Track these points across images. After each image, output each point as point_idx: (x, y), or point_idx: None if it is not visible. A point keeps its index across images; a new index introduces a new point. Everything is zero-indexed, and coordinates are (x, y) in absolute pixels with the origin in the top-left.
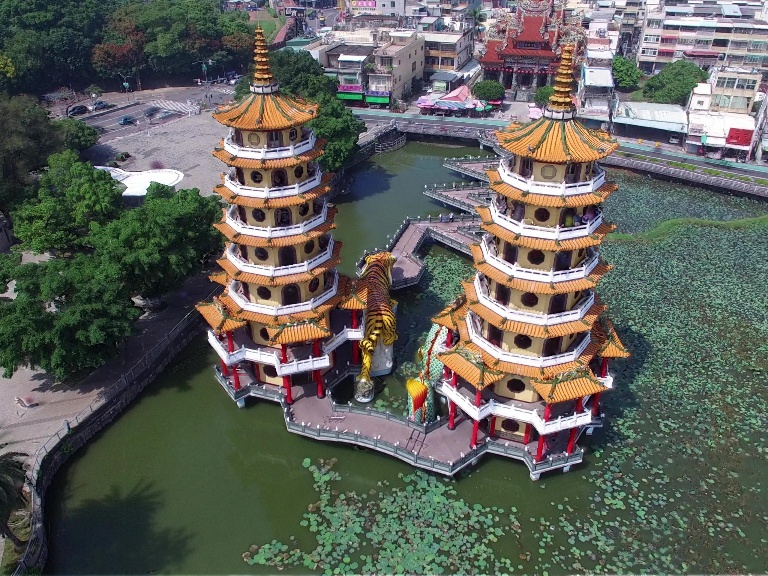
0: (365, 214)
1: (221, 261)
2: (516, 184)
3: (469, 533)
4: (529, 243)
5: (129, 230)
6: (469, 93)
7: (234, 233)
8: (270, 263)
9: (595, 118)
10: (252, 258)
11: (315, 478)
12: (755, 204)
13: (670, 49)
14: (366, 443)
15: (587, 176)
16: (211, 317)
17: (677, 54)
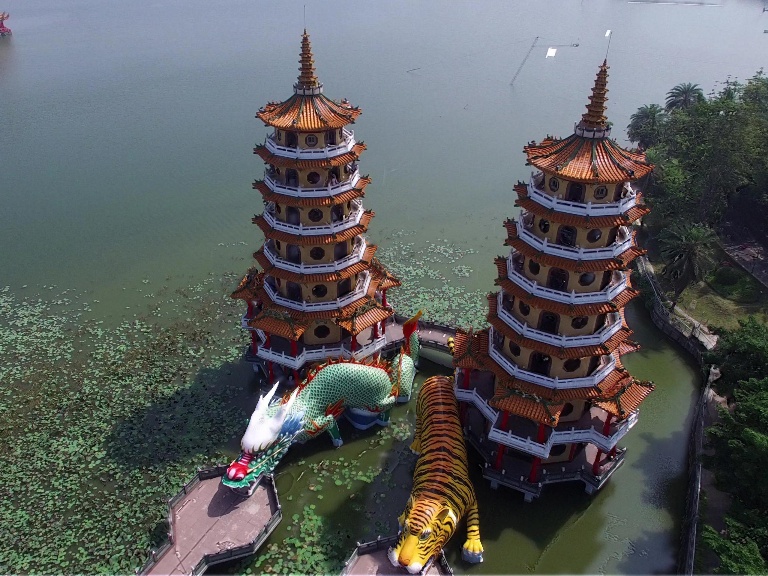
0: None
1: None
2: None
3: None
4: None
5: None
6: None
7: None
8: None
9: None
10: None
11: None
12: None
13: None
14: None
15: None
16: None
17: None
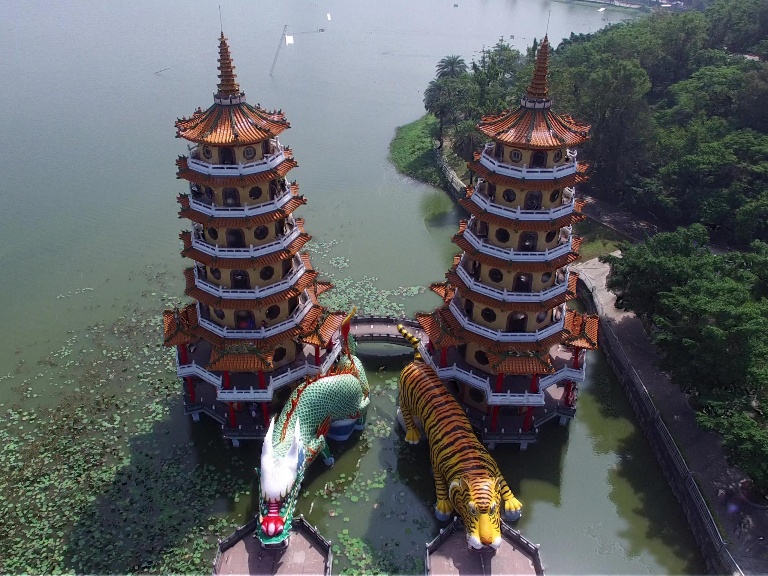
0: None
1: None
2: None
3: None
4: None
5: None
6: None
7: None
8: None
9: None
10: None
11: None
12: None
13: None
14: None
15: None
16: None
17: None
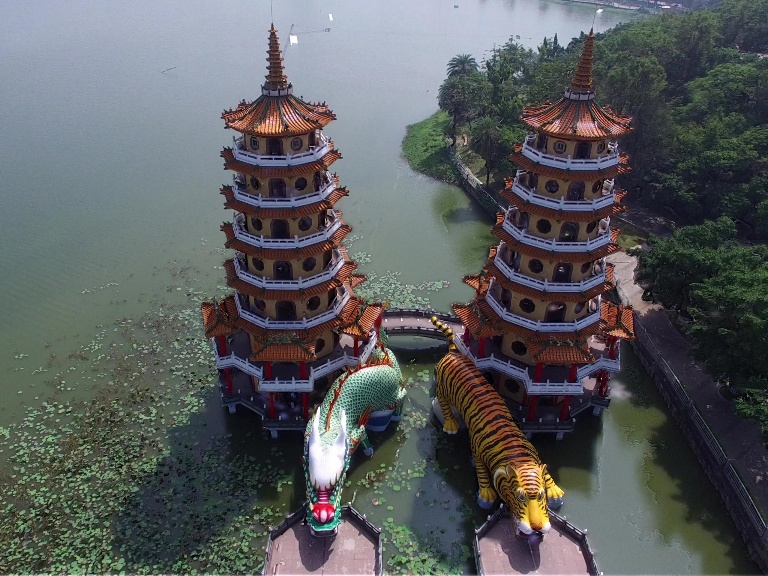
0: None
1: None
2: None
3: None
4: None
5: None
6: None
7: None
8: None
9: None
10: None
11: None
12: None
13: None
14: None
15: None
16: None
17: None
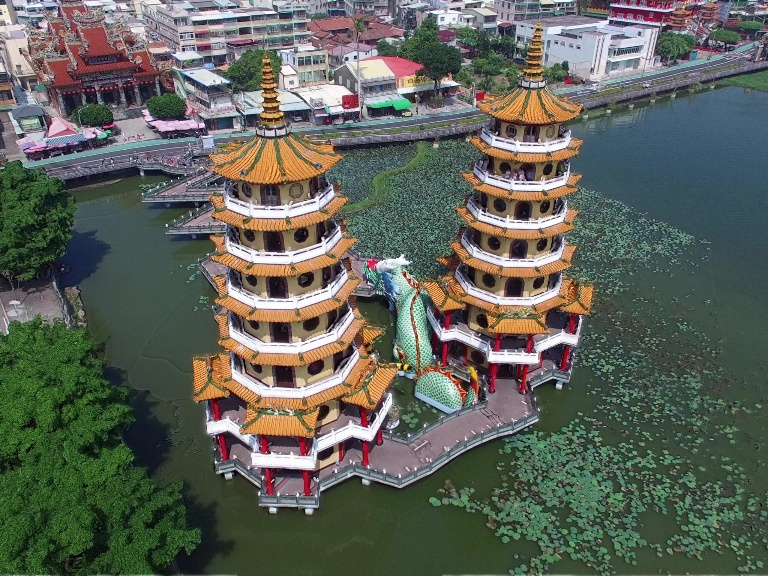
0: (121, 281)
1: (256, 359)
2: (533, 150)
3: (586, 448)
4: (554, 195)
5: (48, 404)
6: (70, 123)
7: (285, 313)
8: (320, 329)
9: (226, 116)
10: (299, 334)
11: (459, 506)
12: (401, 148)
13: (206, 43)
14: (474, 443)
15: (560, 128)
16: (278, 428)
17: (214, 47)
